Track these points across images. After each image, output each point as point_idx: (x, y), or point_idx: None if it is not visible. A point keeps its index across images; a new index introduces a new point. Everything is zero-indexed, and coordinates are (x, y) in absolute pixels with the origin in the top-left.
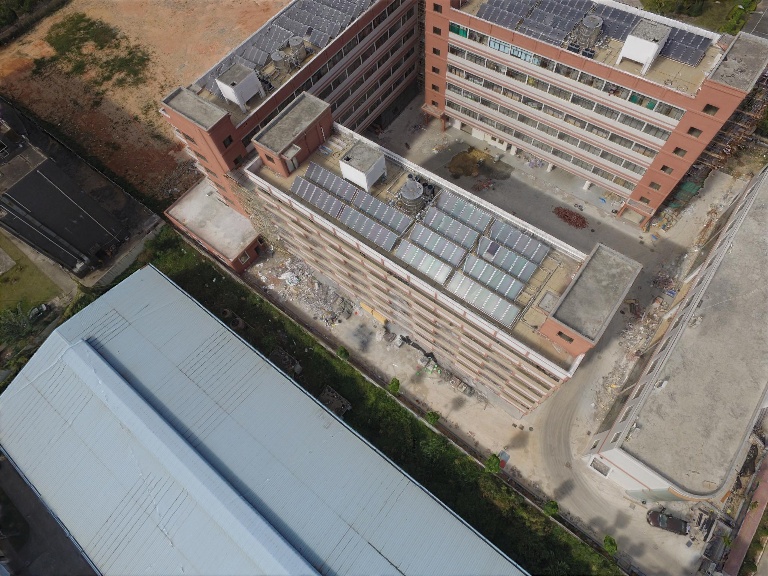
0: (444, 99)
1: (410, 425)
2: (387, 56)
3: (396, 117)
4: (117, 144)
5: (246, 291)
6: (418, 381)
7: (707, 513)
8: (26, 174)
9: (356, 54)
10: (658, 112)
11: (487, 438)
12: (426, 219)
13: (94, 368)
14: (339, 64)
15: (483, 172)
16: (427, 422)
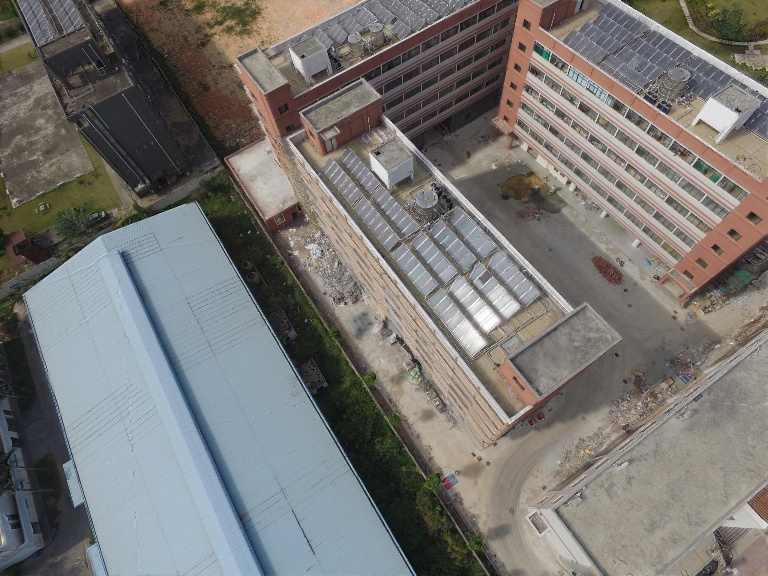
0: (516, 117)
1: (374, 420)
2: (470, 61)
3: (468, 123)
4: (208, 86)
5: (273, 250)
6: (397, 382)
7: None
8: (112, 95)
9: (435, 53)
10: (721, 187)
11: (443, 457)
12: (433, 230)
13: (119, 279)
14: (414, 59)
15: (534, 200)
16: None
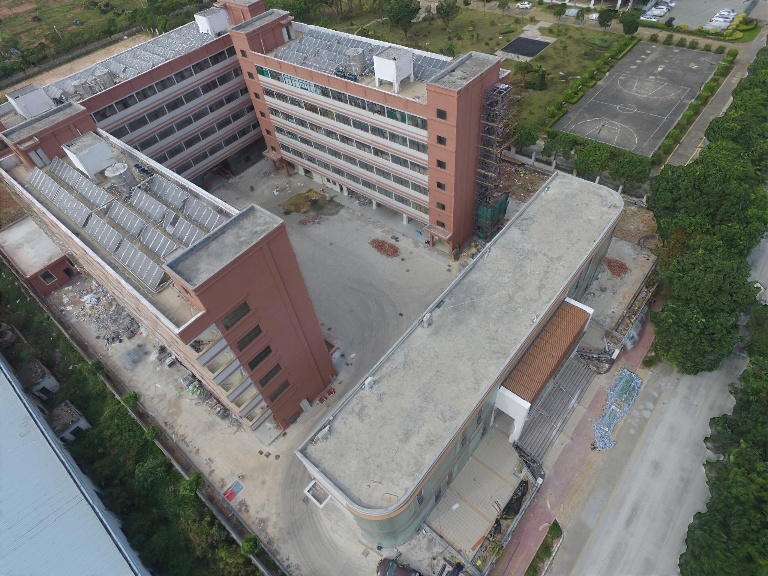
0: (277, 143)
1: (140, 447)
2: (222, 103)
3: (251, 166)
4: None
5: (41, 311)
6: (175, 402)
7: (452, 564)
8: None
9: (175, 93)
10: (410, 125)
11: (225, 466)
12: (131, 199)
13: None
14: (153, 98)
15: (314, 209)
16: (157, 442)
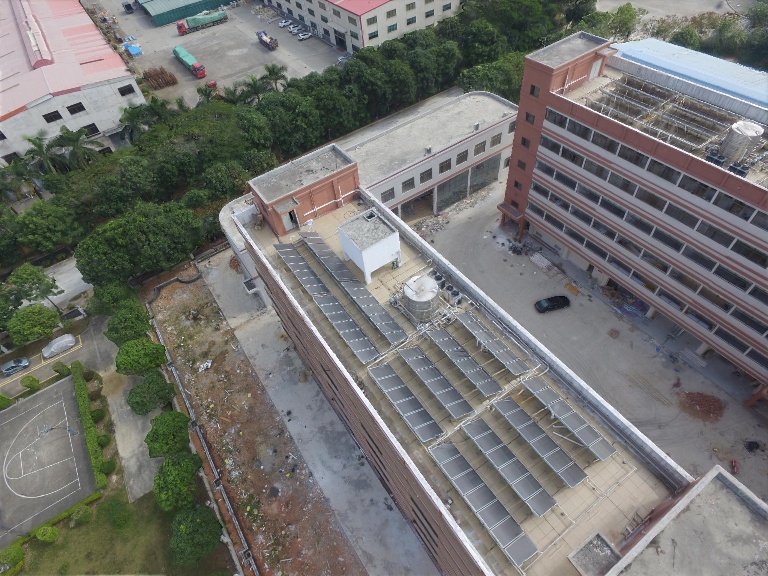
0: None
1: None
2: None
3: None
4: None
5: None
6: None
7: None
8: None
9: None
10: None
11: None
12: None
13: None
14: None
15: None
16: None
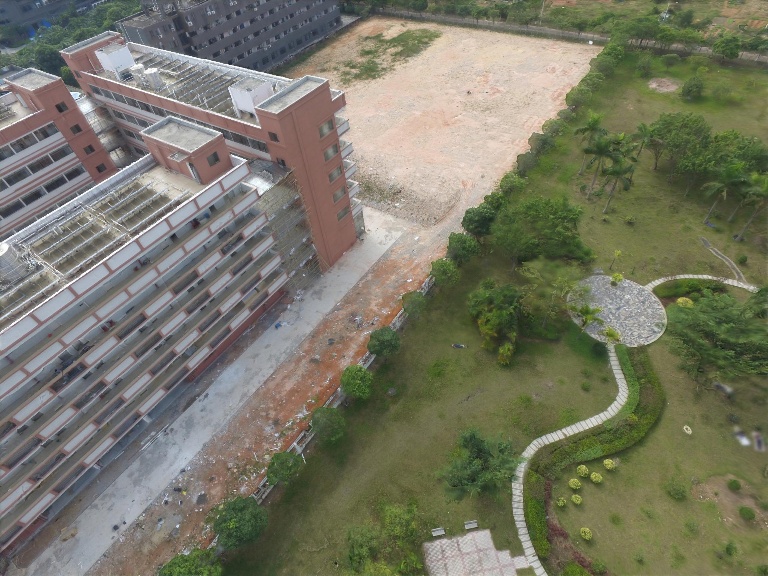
0: None
1: None
2: None
3: None
4: None
5: None
6: None
7: None
8: (134, 26)
9: None
10: None
11: None
12: None
13: None
14: None
15: None
16: None
